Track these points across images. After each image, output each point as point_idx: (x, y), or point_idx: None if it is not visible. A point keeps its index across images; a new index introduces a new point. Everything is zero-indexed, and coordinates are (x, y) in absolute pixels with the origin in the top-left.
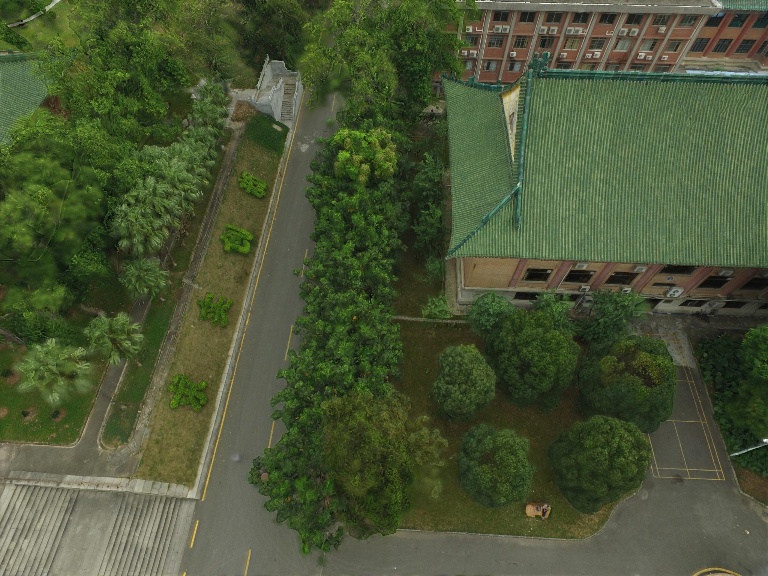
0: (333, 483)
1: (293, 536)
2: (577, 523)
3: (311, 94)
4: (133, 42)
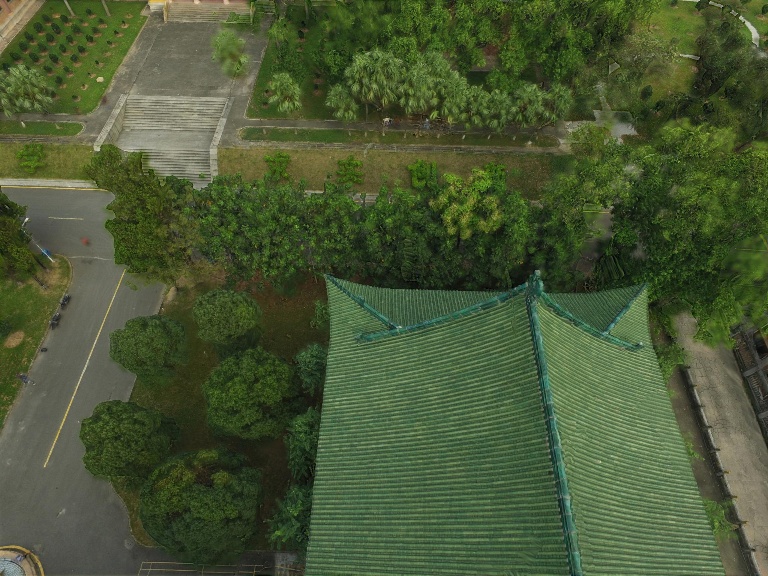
0: None
1: None
2: None
3: None
4: (531, 0)
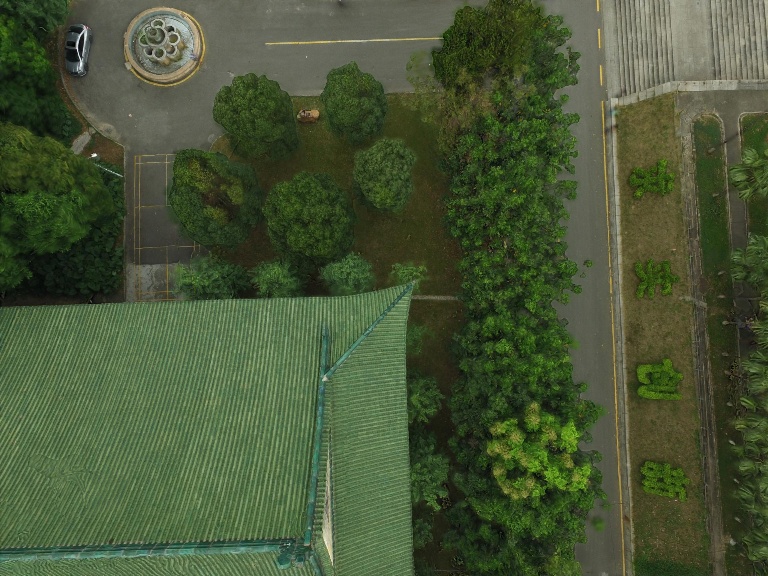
0: None
1: None
2: None
3: None
4: None
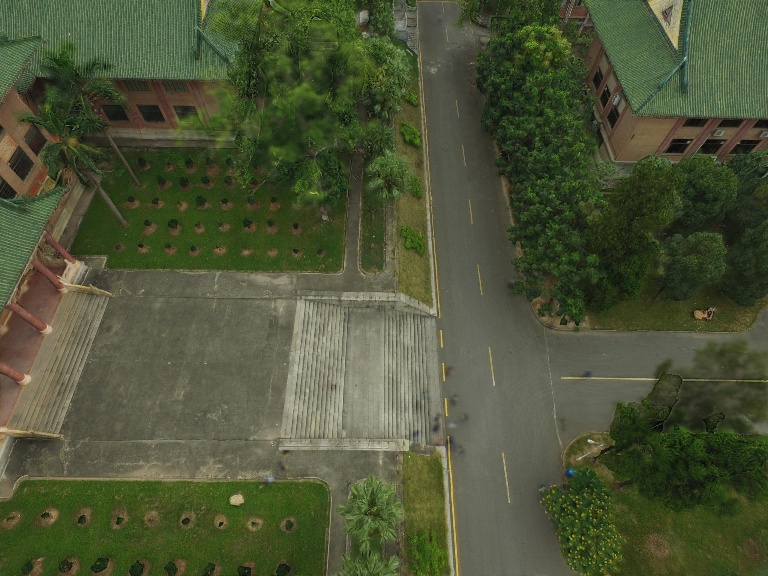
0: (598, 256)
1: (519, 337)
2: (734, 322)
3: (463, 13)
4: None
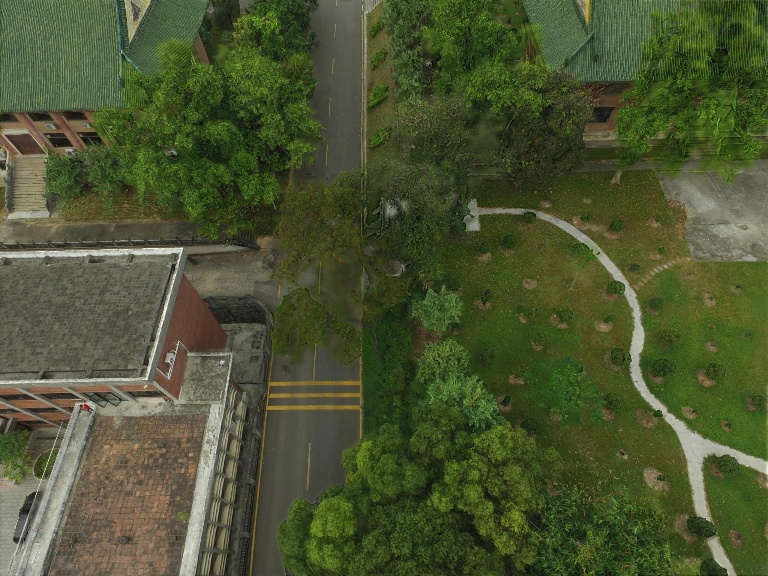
0: None
1: None
2: None
3: None
4: (444, 2)
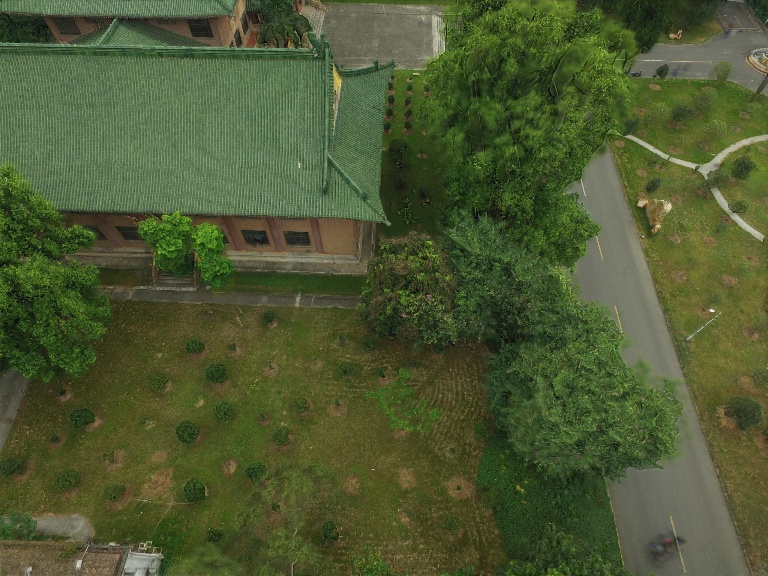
0: None
1: None
2: (694, 40)
3: None
4: None
